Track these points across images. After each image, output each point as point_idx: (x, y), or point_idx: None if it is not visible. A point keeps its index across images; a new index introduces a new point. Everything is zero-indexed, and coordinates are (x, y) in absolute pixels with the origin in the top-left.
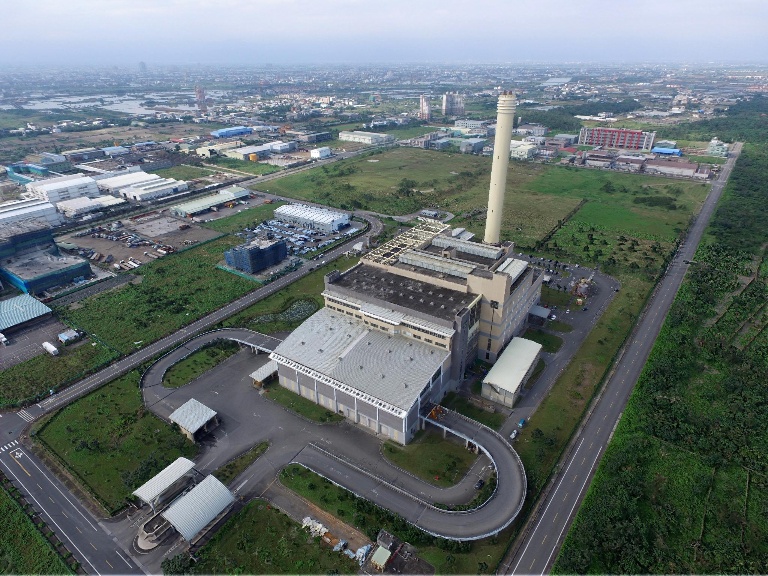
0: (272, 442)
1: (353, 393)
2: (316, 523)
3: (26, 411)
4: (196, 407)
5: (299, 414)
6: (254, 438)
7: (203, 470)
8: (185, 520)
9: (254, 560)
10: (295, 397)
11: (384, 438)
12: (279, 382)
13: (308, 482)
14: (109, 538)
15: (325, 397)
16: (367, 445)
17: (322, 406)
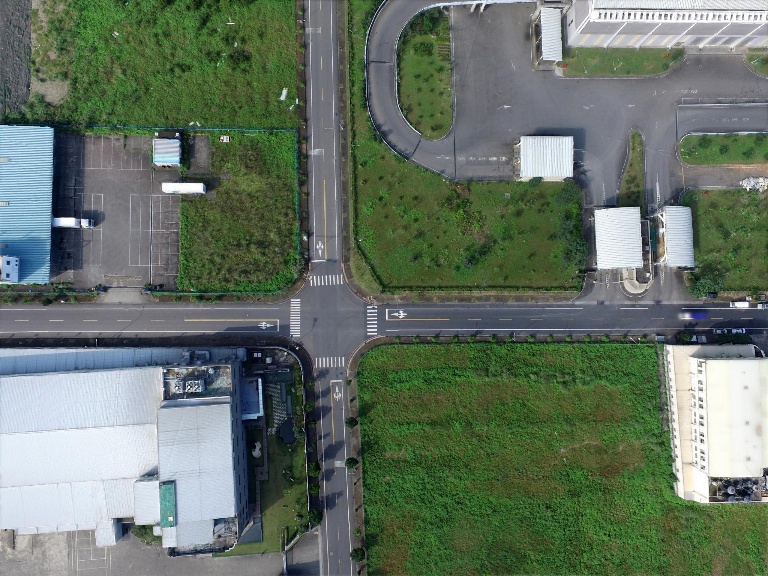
0: (640, 128)
1: (749, 19)
2: (757, 180)
3: (317, 276)
4: (541, 145)
5: (633, 75)
6: (617, 136)
7: (607, 201)
8: (687, 256)
9: (737, 240)
10: (606, 54)
11: (743, 50)
12: (568, 43)
13: (715, 147)
14: (601, 306)
15: (663, 36)
16: (733, 70)
17: (647, 48)
